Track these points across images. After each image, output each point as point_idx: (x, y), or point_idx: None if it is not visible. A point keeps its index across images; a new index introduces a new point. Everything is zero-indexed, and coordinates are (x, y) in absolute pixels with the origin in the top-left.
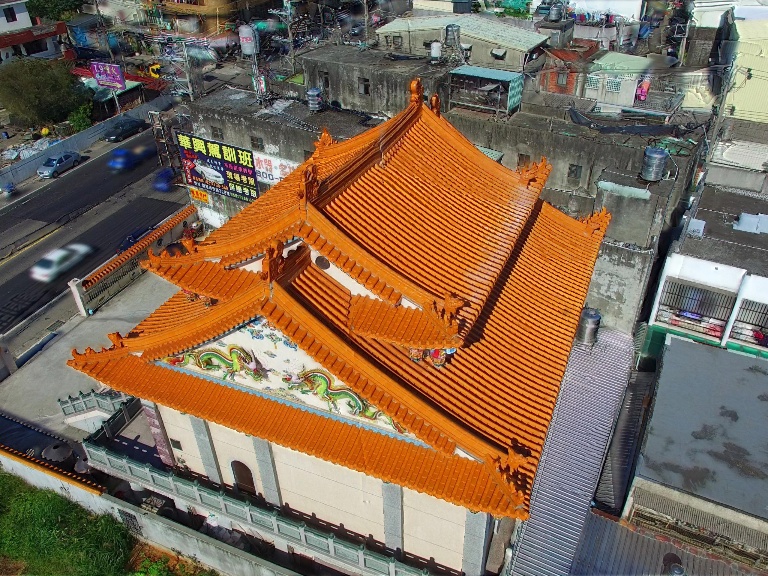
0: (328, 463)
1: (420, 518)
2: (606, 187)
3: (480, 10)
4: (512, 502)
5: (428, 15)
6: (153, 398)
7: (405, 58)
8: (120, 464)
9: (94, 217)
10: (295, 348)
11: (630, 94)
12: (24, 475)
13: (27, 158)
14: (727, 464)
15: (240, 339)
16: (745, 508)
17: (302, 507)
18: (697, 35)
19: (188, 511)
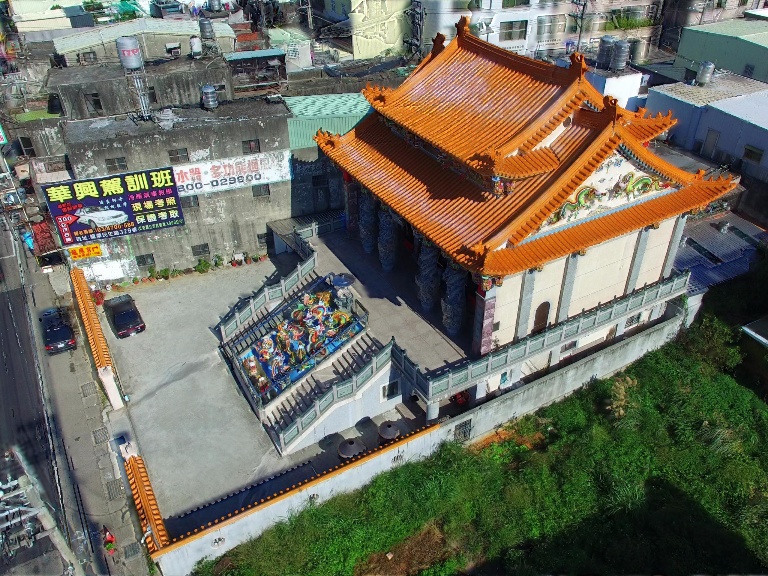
0: (608, 252)
1: (648, 255)
2: None
3: (100, 20)
4: (725, 185)
5: (93, 28)
6: (544, 260)
7: (164, 61)
8: (461, 377)
9: None
10: (620, 164)
11: (308, 56)
12: (347, 485)
13: None
14: None
15: (586, 180)
16: None
17: (577, 310)
18: (286, 9)
19: (486, 394)
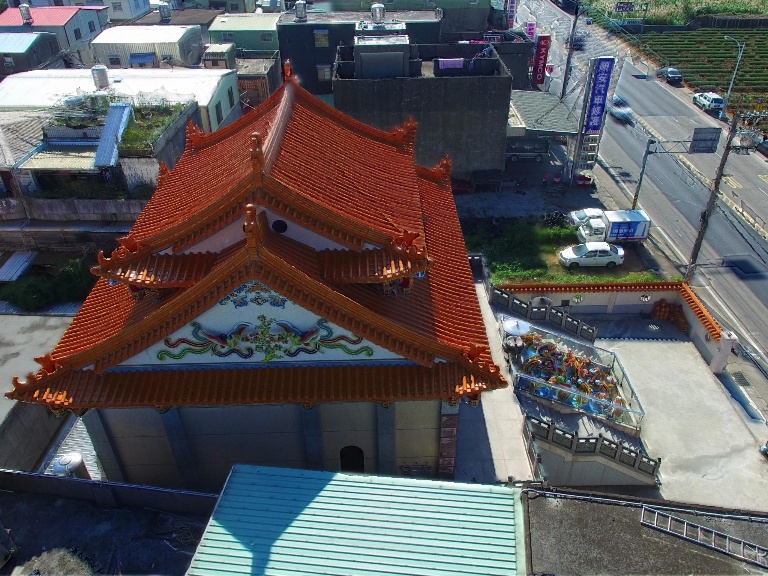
0: None
1: None
2: None
3: None
4: None
5: None
6: None
7: None
8: None
9: None
10: None
11: None
12: None
13: None
14: (4, 340)
15: None
16: (11, 317)
17: None
18: None
19: None
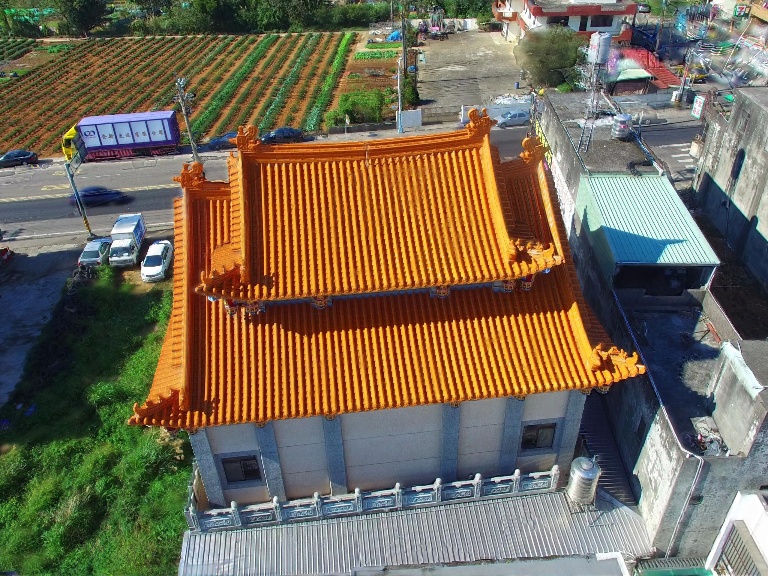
0: None
1: None
2: (728, 353)
3: None
4: None
5: None
6: None
7: None
8: None
9: None
10: None
11: None
12: None
13: (495, 105)
14: None
15: None
16: None
17: None
18: None
19: None
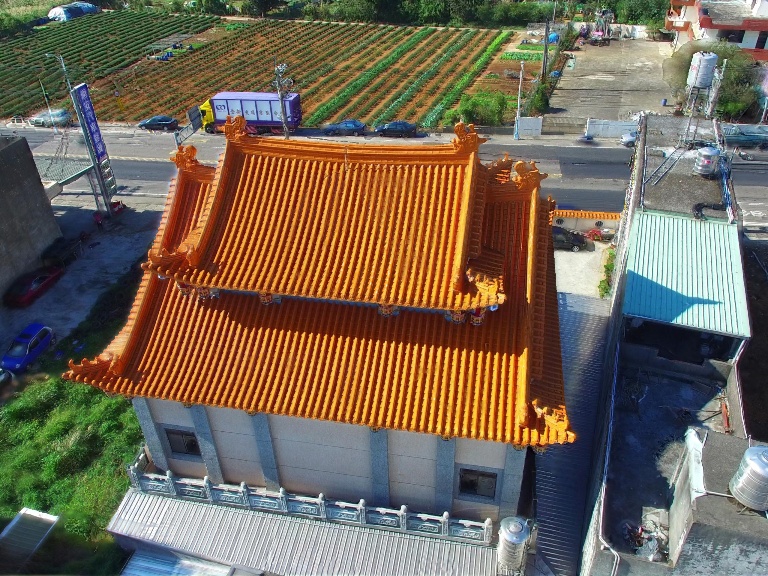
0: None
1: None
2: (689, 442)
3: None
4: None
5: None
6: None
7: None
8: None
9: (586, 184)
10: None
11: None
12: None
13: None
14: None
15: None
16: None
17: None
18: None
19: None
